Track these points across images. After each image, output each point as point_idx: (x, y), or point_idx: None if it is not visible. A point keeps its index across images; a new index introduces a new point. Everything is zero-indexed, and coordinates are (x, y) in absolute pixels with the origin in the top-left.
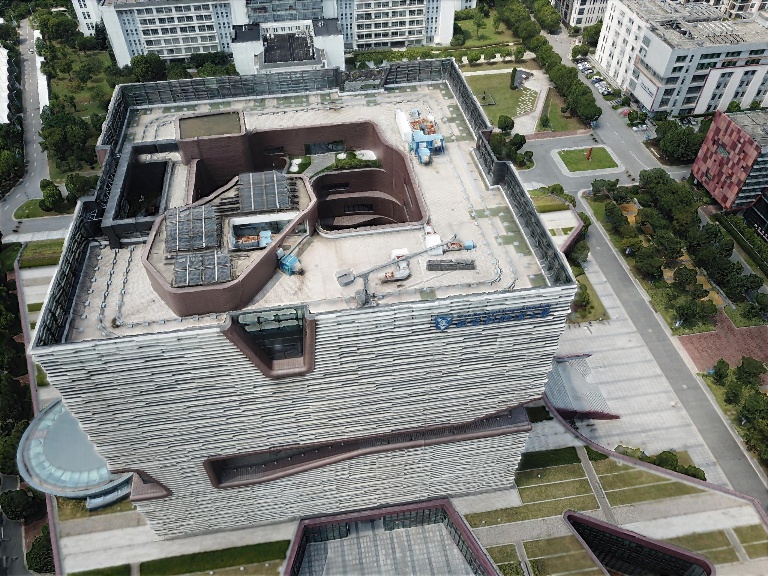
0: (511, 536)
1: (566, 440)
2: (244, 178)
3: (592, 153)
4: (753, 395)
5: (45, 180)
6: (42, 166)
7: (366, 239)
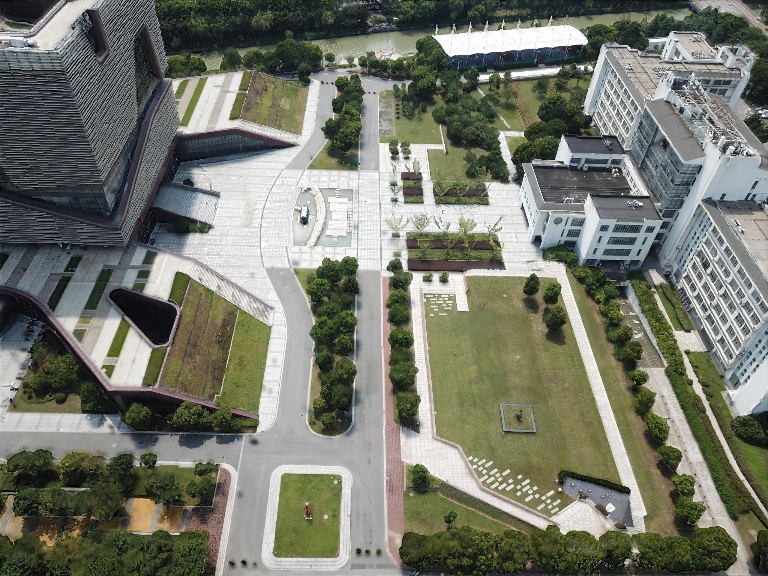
0: None
1: None
2: None
3: (323, 527)
4: None
5: (356, 75)
6: (407, 85)
7: None
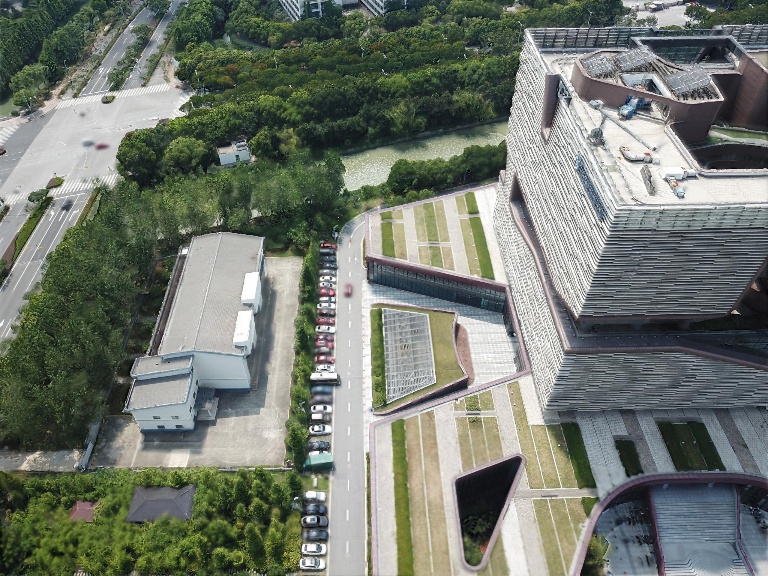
0: (501, 410)
1: (604, 482)
2: (697, 69)
3: None
4: None
5: None
6: None
7: (670, 145)
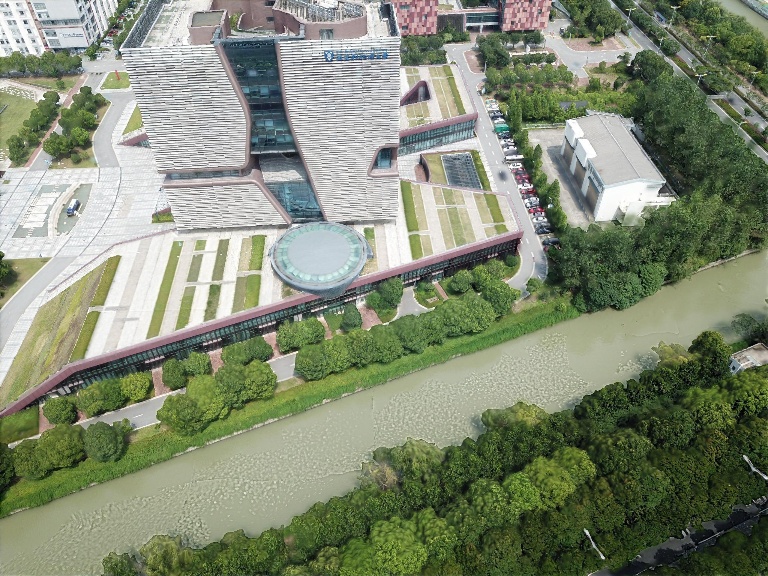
0: (404, 121)
1: None
2: None
3: (114, 77)
4: None
5: None
6: None
7: None
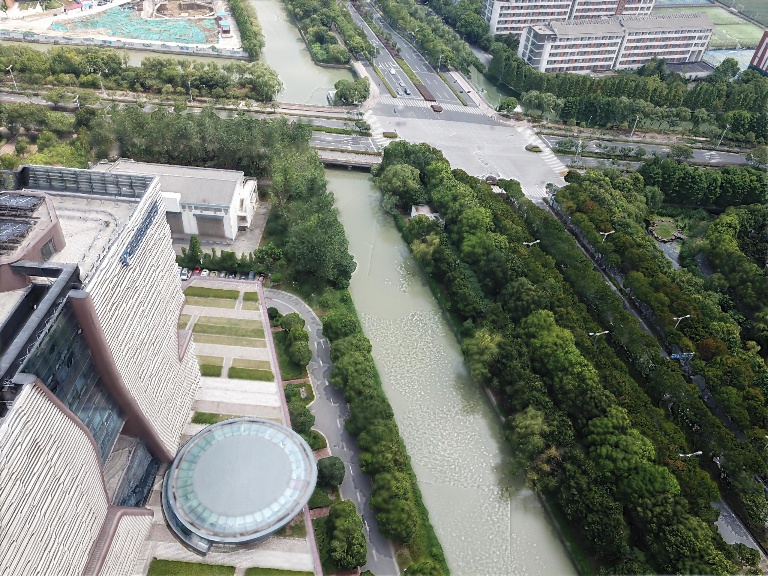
0: None
1: None
2: None
3: None
4: None
5: None
6: None
7: None
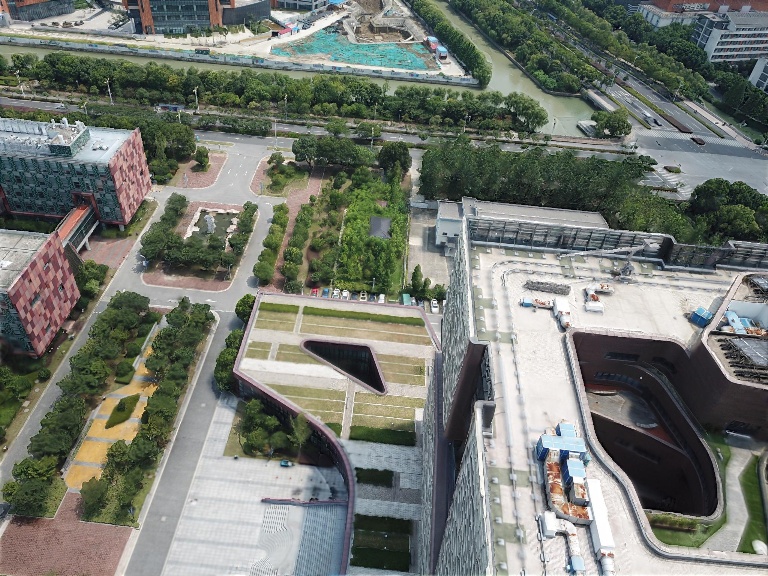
0: None
1: (353, 447)
2: None
3: None
4: (133, 457)
5: None
6: None
7: None
